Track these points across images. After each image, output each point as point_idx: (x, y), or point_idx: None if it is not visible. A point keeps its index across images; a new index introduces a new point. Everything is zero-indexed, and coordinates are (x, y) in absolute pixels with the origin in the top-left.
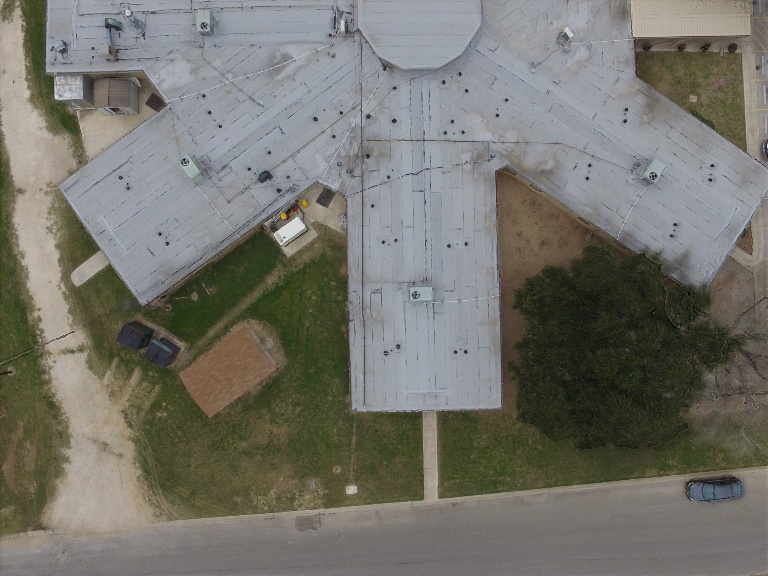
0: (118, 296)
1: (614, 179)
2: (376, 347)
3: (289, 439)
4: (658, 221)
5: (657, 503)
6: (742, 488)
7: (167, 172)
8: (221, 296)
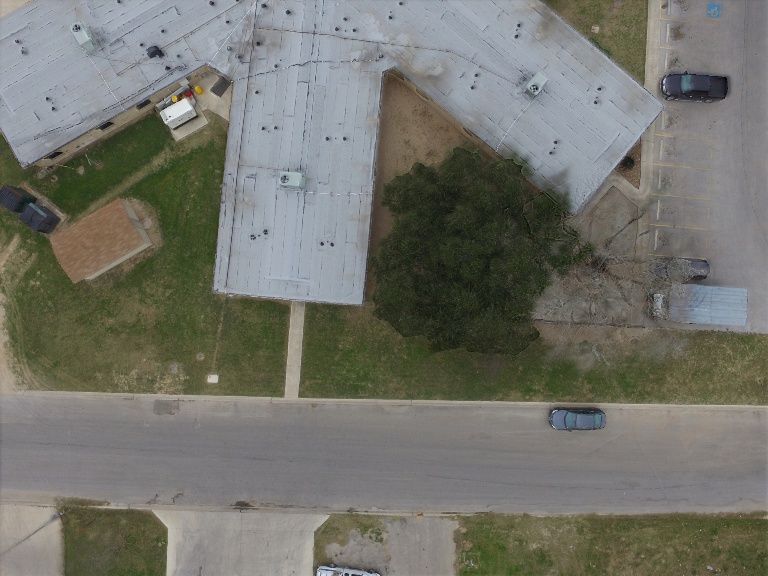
0: (7, 163)
1: (499, 92)
2: (244, 231)
3: (157, 321)
4: (539, 138)
5: (520, 429)
6: (609, 424)
7: (62, 40)
8: (106, 172)
